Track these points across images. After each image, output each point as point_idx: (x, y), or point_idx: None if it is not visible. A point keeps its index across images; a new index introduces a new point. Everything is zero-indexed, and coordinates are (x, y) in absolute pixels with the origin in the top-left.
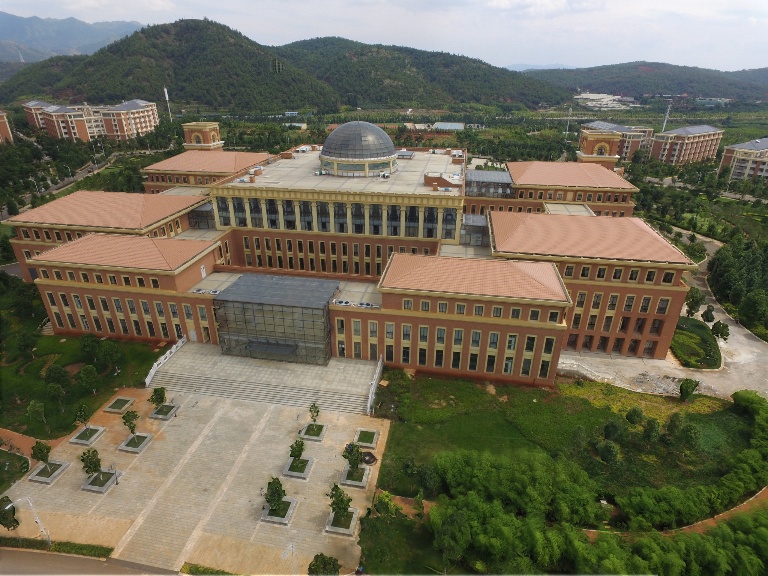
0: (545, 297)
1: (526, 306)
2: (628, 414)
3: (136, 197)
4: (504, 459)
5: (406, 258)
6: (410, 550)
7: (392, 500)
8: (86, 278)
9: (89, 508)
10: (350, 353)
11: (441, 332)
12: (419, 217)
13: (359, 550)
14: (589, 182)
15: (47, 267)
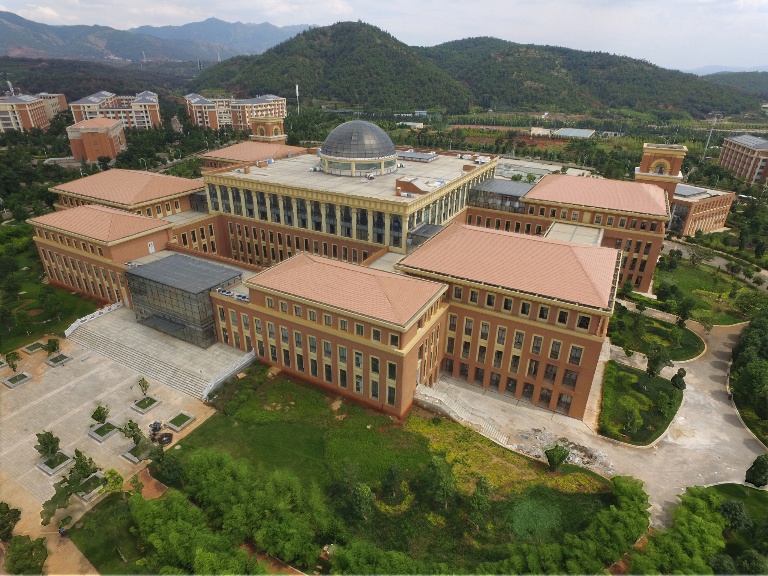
0: (384, 317)
1: (366, 324)
2: None
3: (146, 178)
4: None
5: (300, 258)
6: (119, 529)
7: (147, 481)
8: (62, 240)
9: None
10: (231, 341)
11: (299, 336)
12: (368, 221)
13: (81, 515)
14: (613, 203)
15: (39, 228)
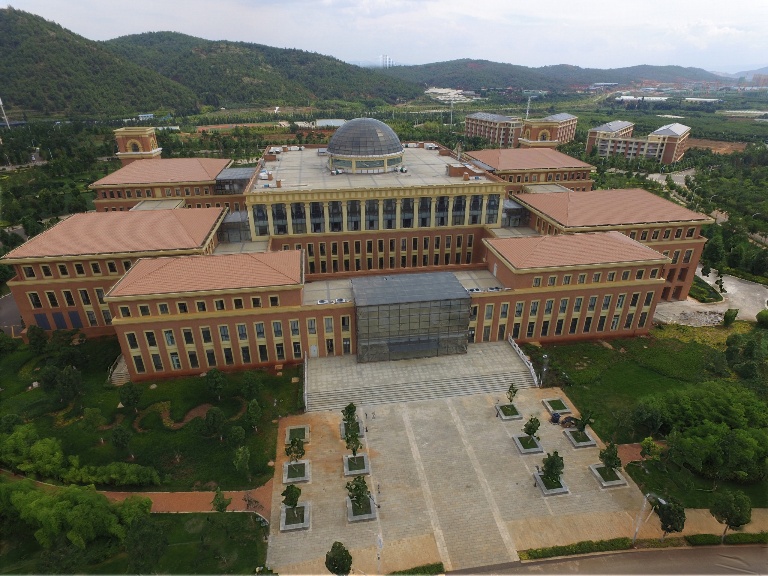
0: (649, 258)
1: (635, 268)
2: (729, 340)
3: (162, 214)
4: (698, 391)
5: (507, 242)
6: None
7: (625, 448)
8: (183, 308)
9: (377, 536)
10: (480, 338)
11: (564, 303)
12: (466, 206)
13: (641, 493)
14: (555, 164)
15: (131, 303)
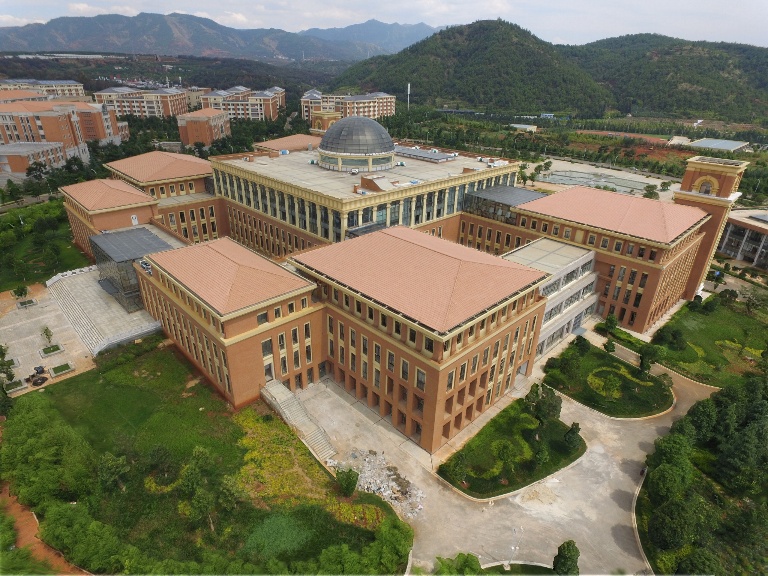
0: (214, 304)
1: None
2: None
3: (171, 160)
4: None
5: None
6: None
7: None
8: None
9: None
10: (150, 310)
11: None
12: (317, 215)
13: None
14: (611, 223)
15: None
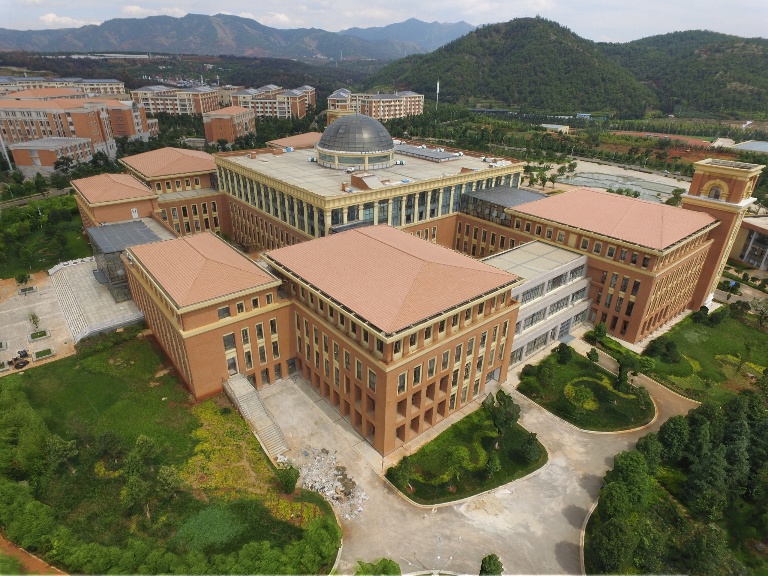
0: (175, 297)
1: None
2: None
3: (179, 156)
4: None
5: None
6: None
7: None
8: None
9: None
10: (136, 301)
11: None
12: (304, 212)
13: None
14: (605, 227)
15: None
